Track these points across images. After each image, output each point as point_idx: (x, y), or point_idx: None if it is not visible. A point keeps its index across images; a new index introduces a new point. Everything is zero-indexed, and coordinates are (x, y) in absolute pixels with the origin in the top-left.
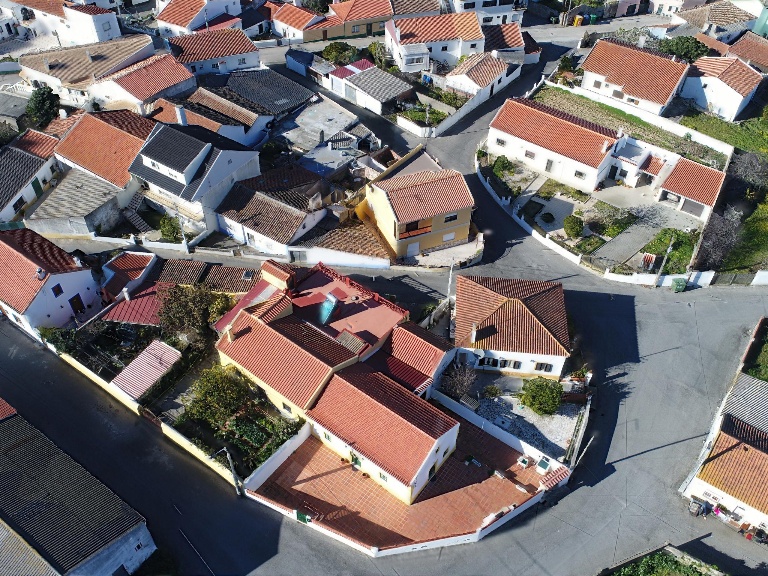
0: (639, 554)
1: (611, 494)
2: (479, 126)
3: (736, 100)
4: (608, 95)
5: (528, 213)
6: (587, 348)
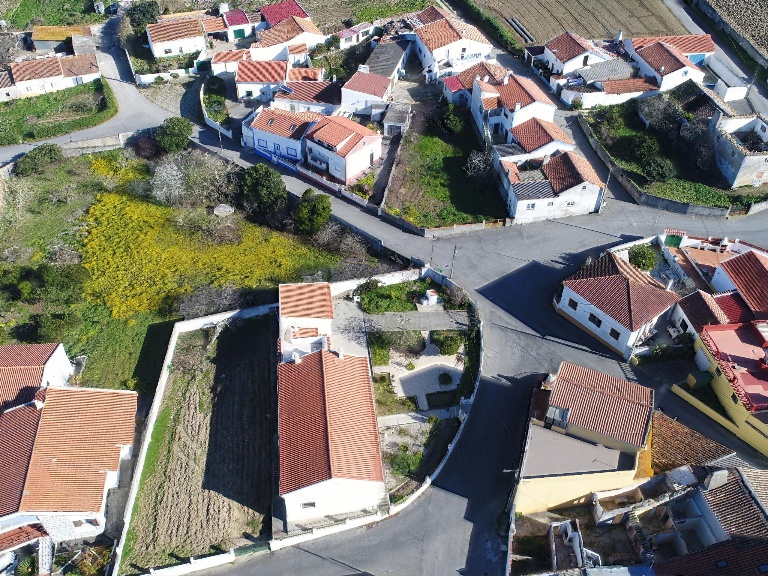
0: (664, 198)
1: (637, 230)
2: (318, 568)
3: (62, 353)
4: (115, 480)
5: (452, 398)
6: (557, 284)
